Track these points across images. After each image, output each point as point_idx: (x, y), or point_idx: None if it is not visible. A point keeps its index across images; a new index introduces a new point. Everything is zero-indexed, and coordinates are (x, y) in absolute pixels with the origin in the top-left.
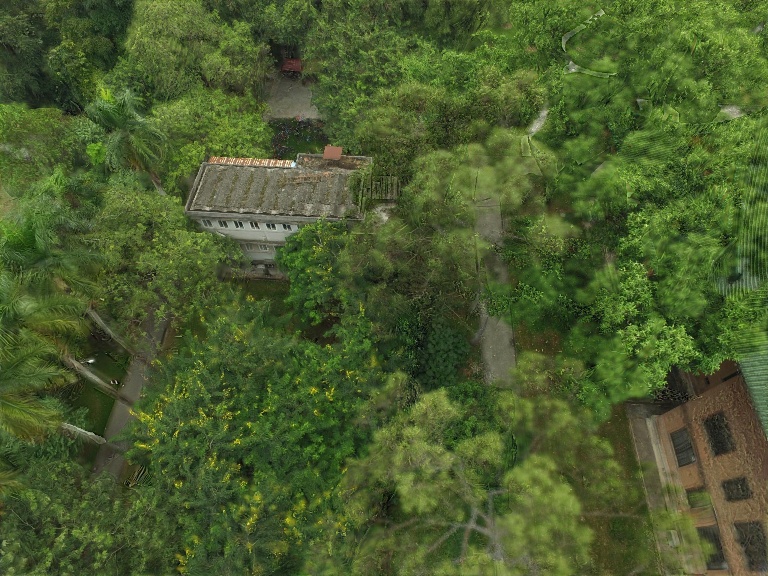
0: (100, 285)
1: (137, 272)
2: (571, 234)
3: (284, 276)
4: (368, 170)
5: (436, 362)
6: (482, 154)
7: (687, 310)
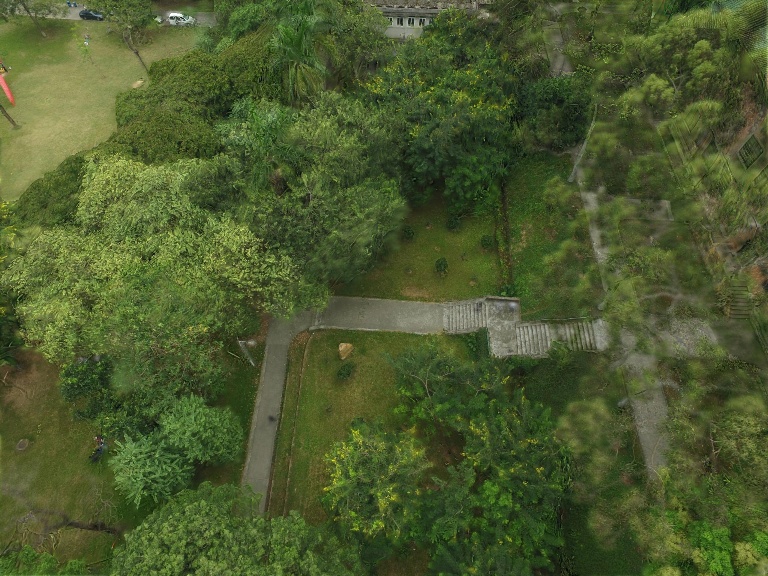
0: None
1: (341, 28)
2: (612, 42)
3: None
4: None
5: (528, 99)
6: None
7: (695, 2)
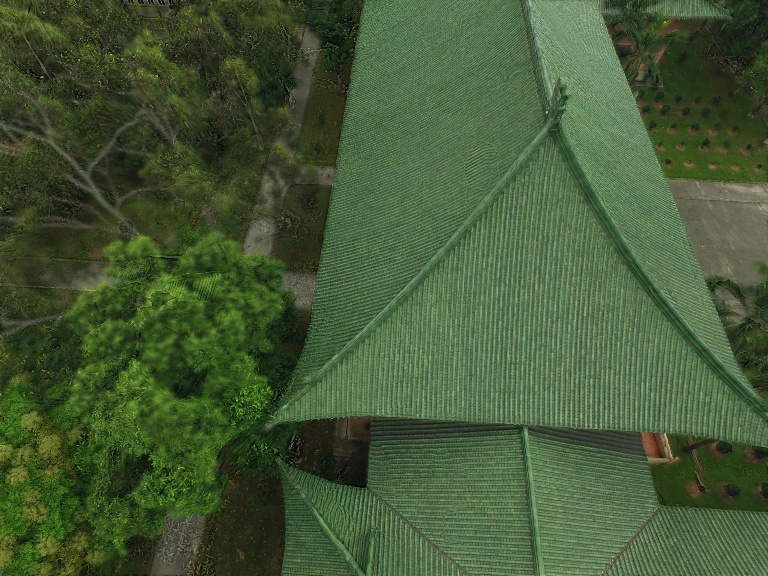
0: (42, 0)
1: (67, 5)
2: None
3: (172, 39)
4: None
5: None
6: None
7: None
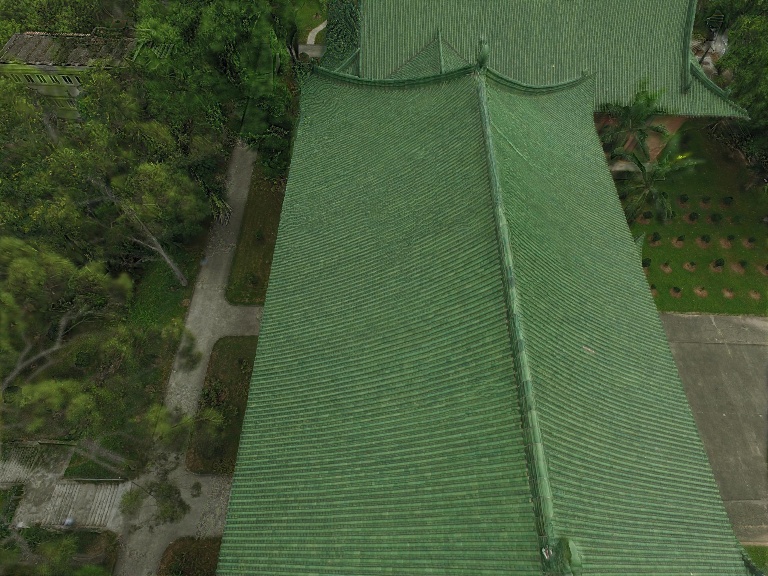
0: None
1: None
2: None
3: None
4: (150, 39)
5: None
6: None
7: None
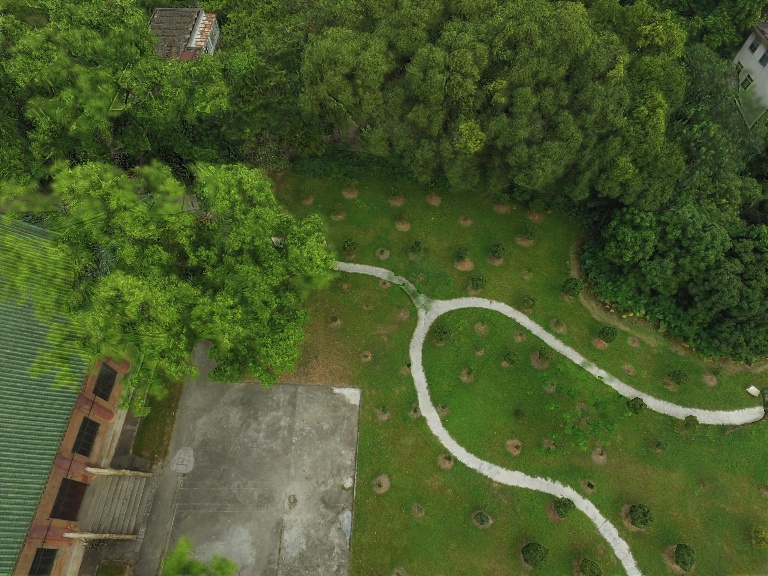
0: None
1: None
2: None
3: None
4: None
5: None
6: None
7: None
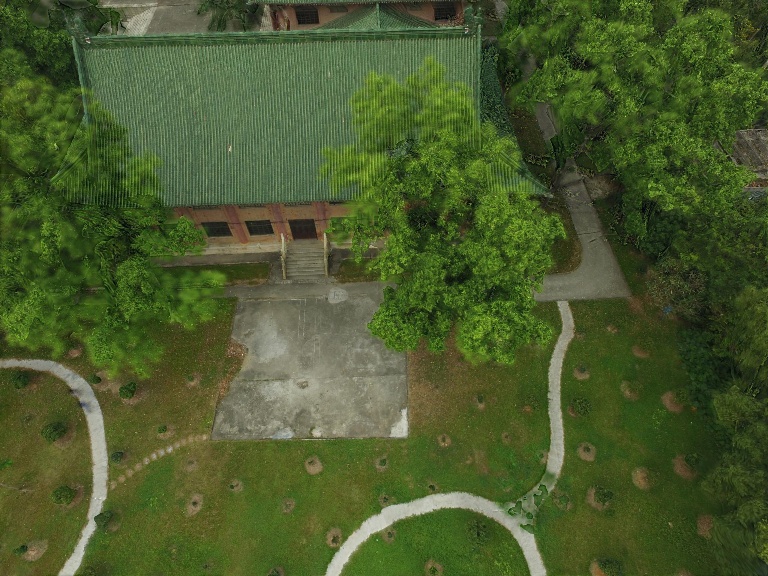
0: None
1: None
2: None
3: None
4: None
5: None
6: (617, 298)
7: None
